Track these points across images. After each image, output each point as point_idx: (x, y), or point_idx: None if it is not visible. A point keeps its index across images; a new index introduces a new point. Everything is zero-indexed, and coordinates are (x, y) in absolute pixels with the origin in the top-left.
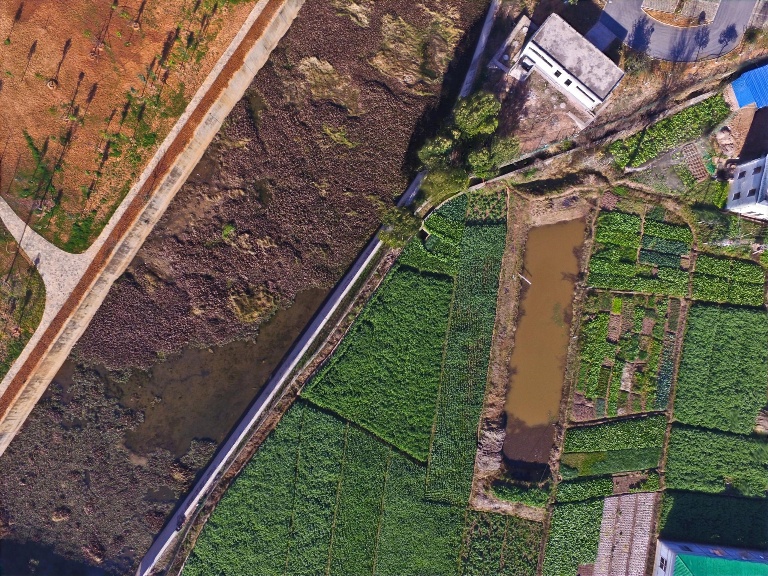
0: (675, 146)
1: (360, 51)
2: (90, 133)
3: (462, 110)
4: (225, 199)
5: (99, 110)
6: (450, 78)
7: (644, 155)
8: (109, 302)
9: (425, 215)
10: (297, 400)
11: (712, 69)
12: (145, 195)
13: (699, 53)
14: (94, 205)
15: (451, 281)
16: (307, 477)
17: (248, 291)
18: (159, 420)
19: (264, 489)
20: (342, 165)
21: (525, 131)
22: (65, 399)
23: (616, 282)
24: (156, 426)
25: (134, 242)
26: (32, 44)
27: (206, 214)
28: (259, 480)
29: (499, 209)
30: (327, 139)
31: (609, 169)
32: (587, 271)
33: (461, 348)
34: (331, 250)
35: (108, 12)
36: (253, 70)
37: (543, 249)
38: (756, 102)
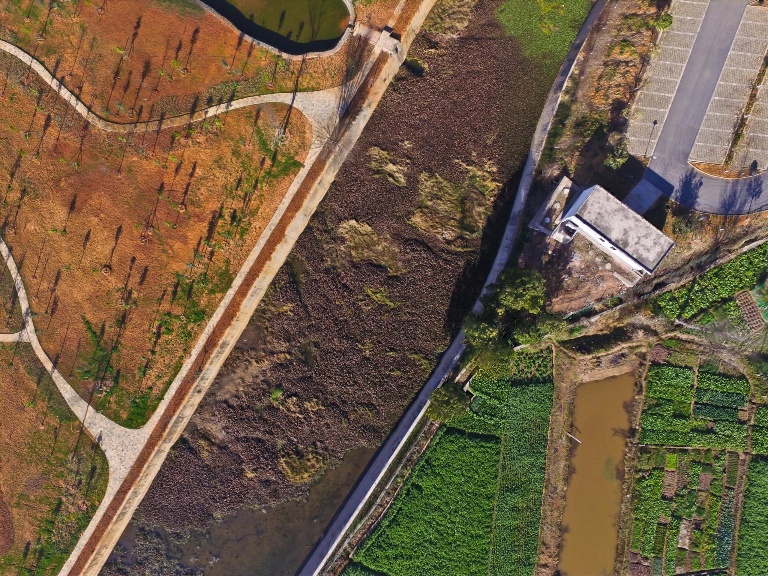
0: (728, 295)
1: (398, 210)
2: (143, 314)
3: (507, 296)
4: (272, 363)
5: (151, 291)
6: (489, 231)
7: (695, 306)
8: (166, 468)
9: (470, 375)
10: (350, 563)
11: (766, 219)
12: (197, 370)
13: (752, 205)
14: (150, 382)
15: (498, 442)
16: None
17: (297, 452)
18: None
19: None
20: (384, 325)
21: (569, 291)
22: (129, 560)
23: (670, 438)
24: None
25: (188, 411)
26: (86, 233)
27: (254, 378)
28: None
29: (545, 367)
30: (369, 300)
31: (658, 324)
32: (639, 427)
33: (511, 509)
34: (377, 409)
35: (155, 197)
36: (294, 237)
37: (592, 405)
38: None
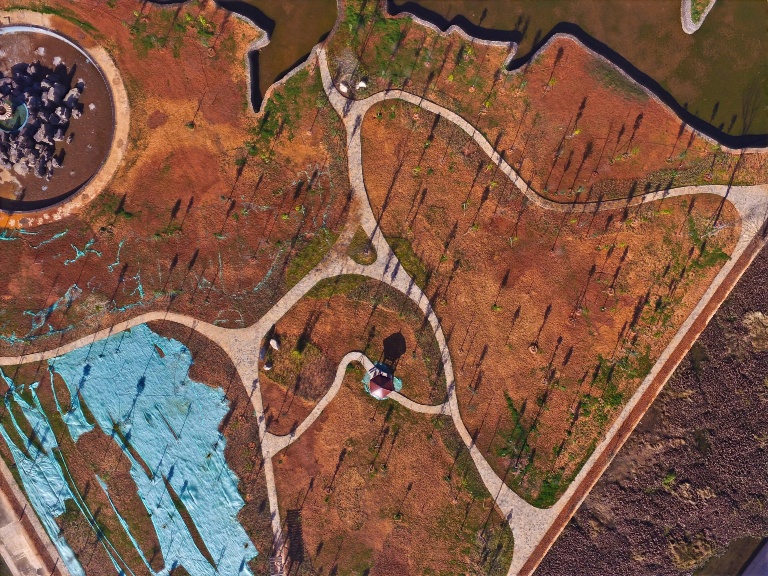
0: None
1: None
2: (564, 394)
3: None
4: (667, 448)
5: (573, 372)
6: None
7: None
8: (556, 546)
9: None
10: None
11: None
12: (609, 453)
13: None
14: (563, 462)
15: None
16: None
17: (685, 538)
18: None
19: None
20: None
21: None
22: None
23: None
24: None
25: None
26: (516, 309)
27: (647, 462)
28: None
29: None
30: (767, 392)
31: None
32: None
33: None
34: (766, 501)
35: (586, 278)
36: None
37: None
38: None
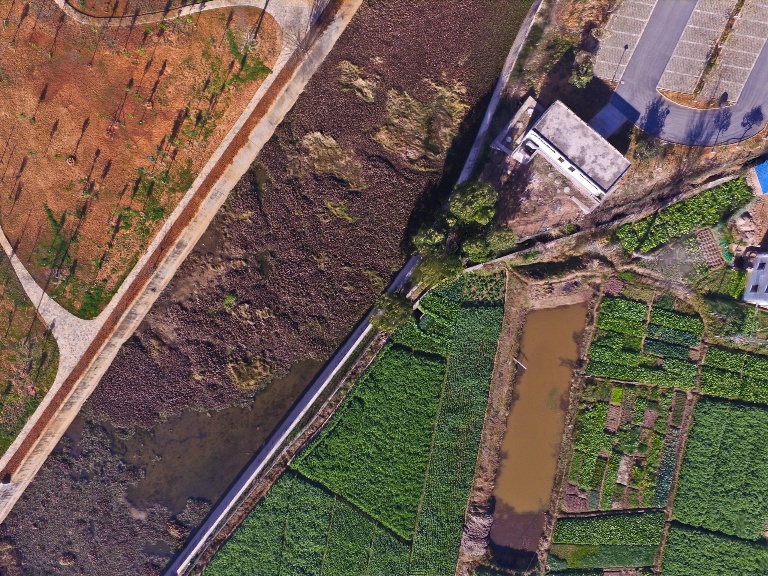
0: (689, 231)
1: (364, 126)
2: (104, 207)
3: (456, 202)
4: (228, 269)
5: (112, 185)
6: (454, 153)
7: (654, 240)
8: (117, 364)
9: (421, 294)
10: (287, 470)
11: (733, 153)
12: (152, 266)
13: (718, 137)
14: (105, 275)
15: (444, 362)
16: (293, 546)
17: (246, 359)
18: (159, 477)
19: (252, 555)
20: (341, 239)
21: (526, 214)
22: (75, 452)
23: (617, 371)
24: (156, 483)
25: (141, 309)
26: (54, 122)
27: (209, 283)
28: (248, 545)
29: (497, 291)
30: (328, 213)
31: (615, 255)
32: (586, 358)
33: (451, 430)
34: (327, 323)
35: (124, 92)
36: (258, 145)
37: (541, 333)
38: None
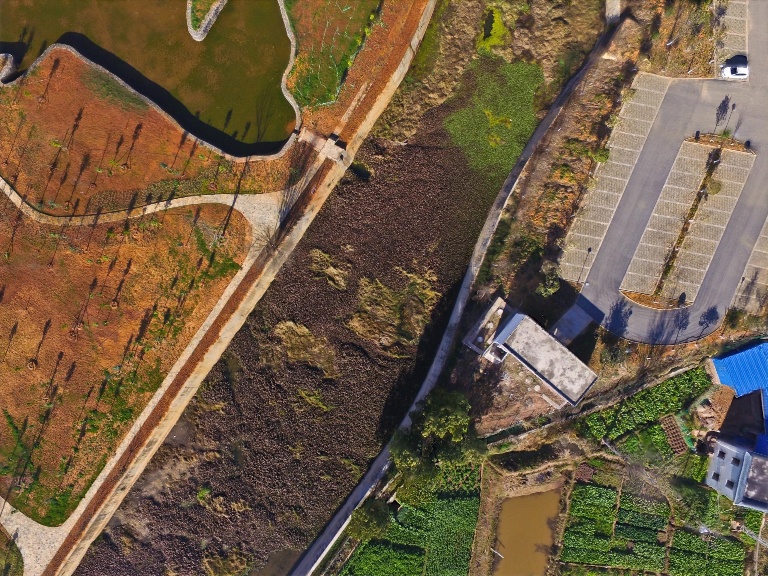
0: (654, 418)
1: (336, 313)
2: (68, 410)
3: (430, 425)
4: (201, 461)
5: (77, 387)
6: (426, 339)
7: (621, 427)
8: (86, 564)
9: (398, 485)
10: None
11: (692, 350)
12: (121, 469)
13: (678, 336)
14: (71, 479)
15: (422, 554)
16: None
17: (222, 552)
18: None
19: None
20: (317, 428)
21: (499, 408)
22: None
23: (590, 557)
24: None
25: (110, 508)
26: (13, 325)
27: (182, 476)
28: None
29: (472, 481)
30: (302, 402)
31: (585, 445)
32: (561, 544)
33: None
34: (304, 512)
35: (87, 292)
36: (230, 336)
37: (517, 519)
38: (736, 390)
